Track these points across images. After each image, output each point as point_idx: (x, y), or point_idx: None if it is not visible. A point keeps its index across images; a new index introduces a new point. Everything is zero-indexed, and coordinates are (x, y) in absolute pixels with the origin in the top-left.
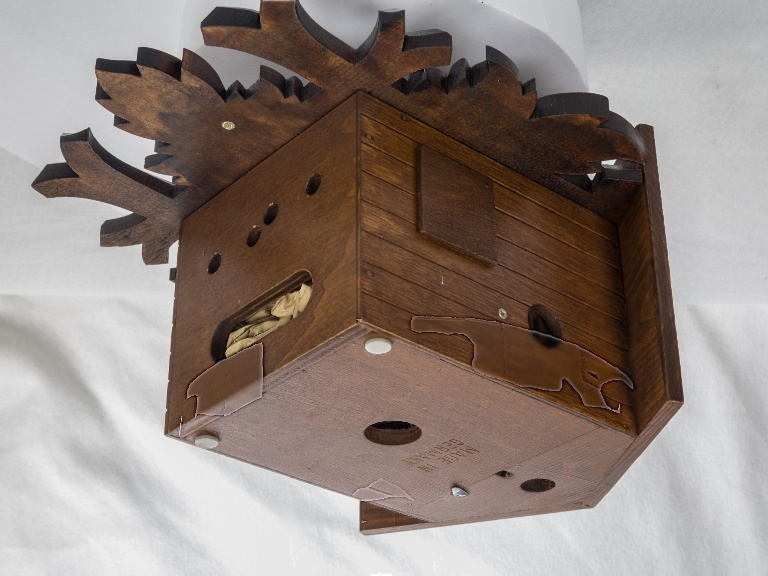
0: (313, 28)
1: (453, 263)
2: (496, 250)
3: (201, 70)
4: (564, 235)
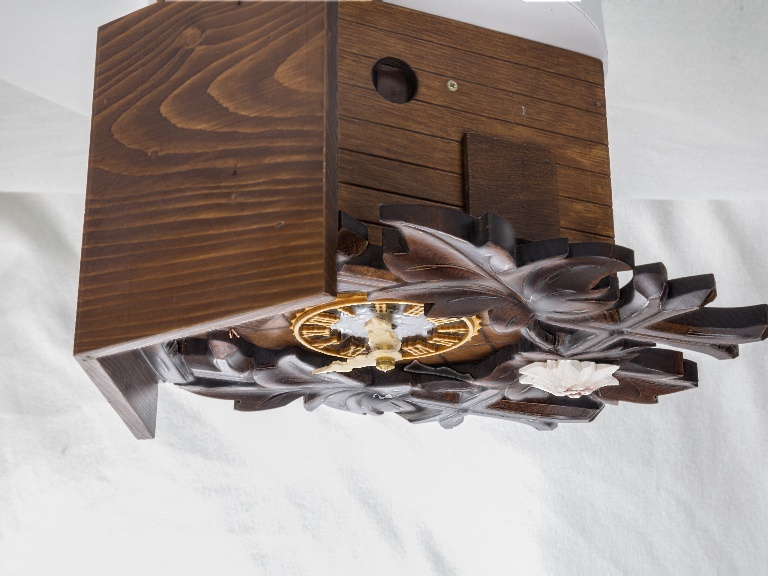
0: (706, 317)
1: (510, 131)
2: (470, 146)
3: (666, 359)
4: (356, 195)
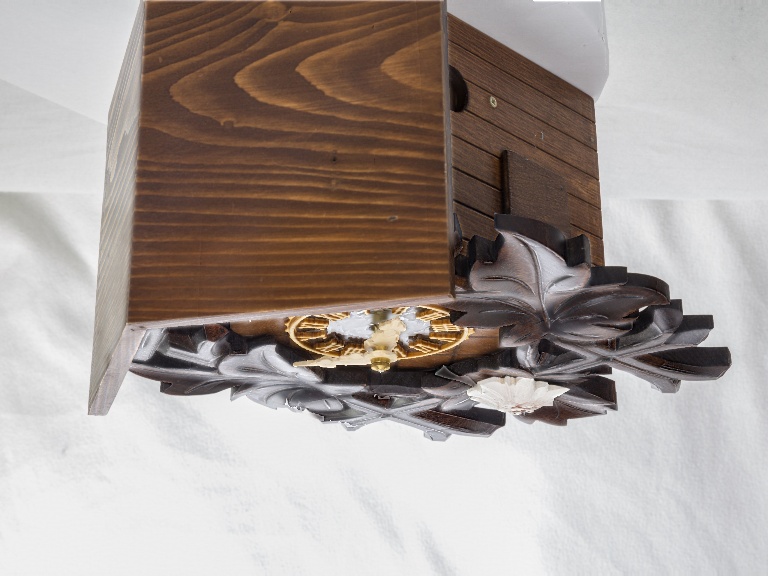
0: (676, 353)
1: (534, 154)
2: (511, 164)
3: (604, 386)
4: None
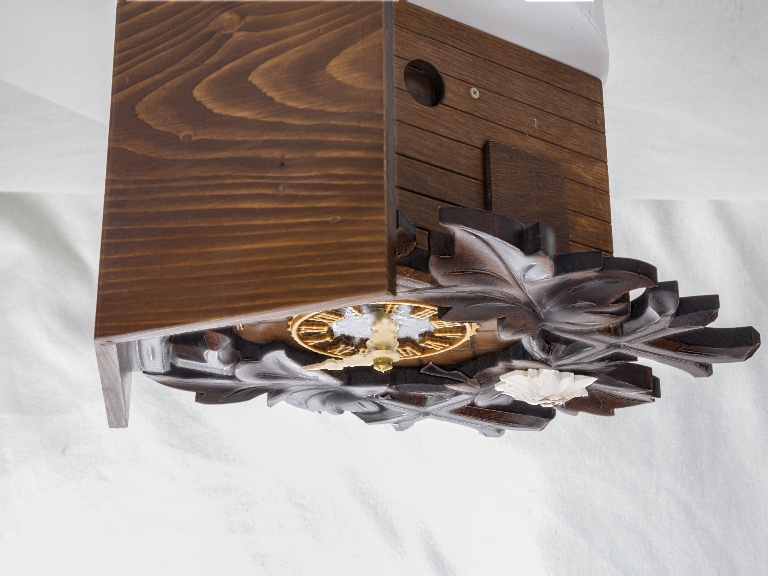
0: (695, 336)
1: (525, 142)
2: (493, 154)
3: (638, 373)
4: None
